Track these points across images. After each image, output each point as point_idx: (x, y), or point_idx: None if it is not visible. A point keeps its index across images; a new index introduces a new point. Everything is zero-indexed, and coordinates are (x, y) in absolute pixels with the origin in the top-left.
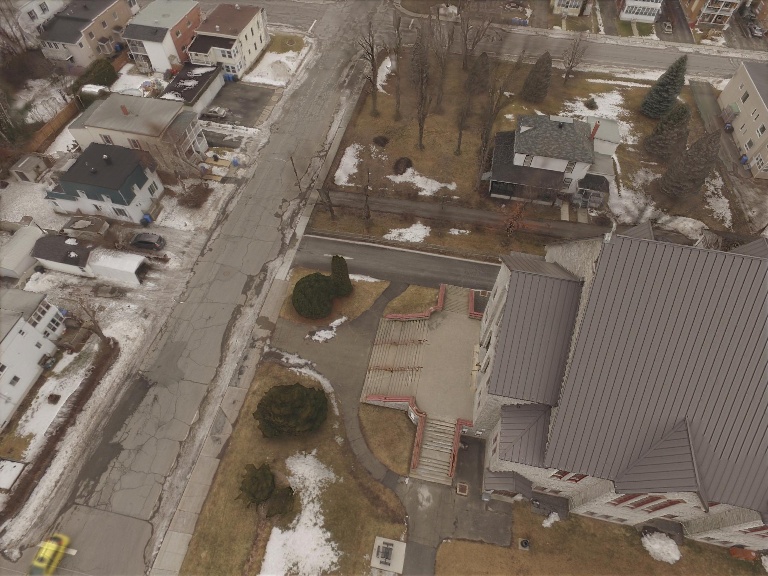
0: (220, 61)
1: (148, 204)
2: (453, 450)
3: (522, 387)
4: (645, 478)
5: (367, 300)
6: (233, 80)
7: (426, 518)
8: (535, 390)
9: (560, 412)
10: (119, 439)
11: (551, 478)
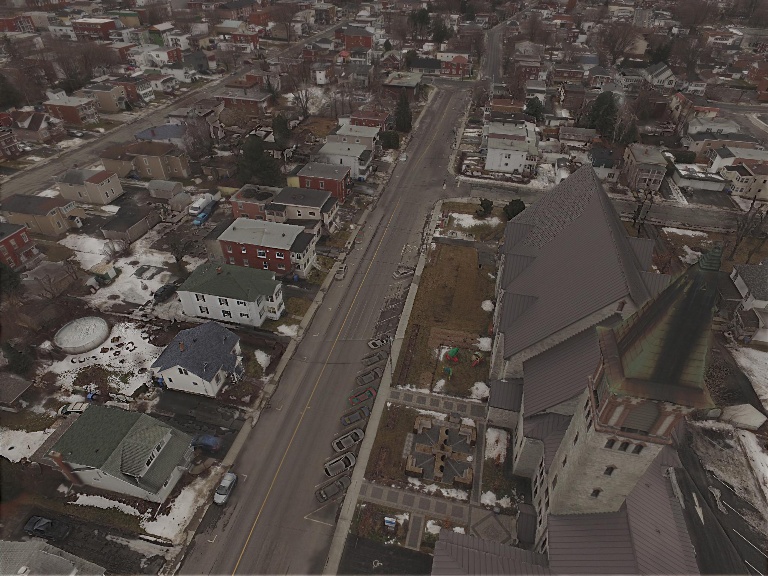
0: (733, 180)
1: (602, 178)
2: None
3: None
4: None
5: None
6: (728, 193)
7: None
8: None
9: None
10: None
11: None
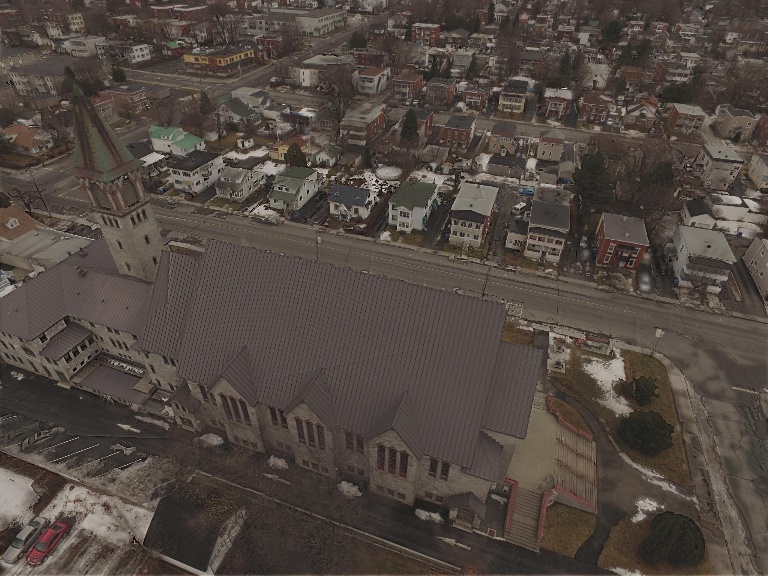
0: None
1: None
2: None
3: None
4: None
5: (618, 539)
6: None
7: None
8: None
9: None
10: (763, 442)
11: None
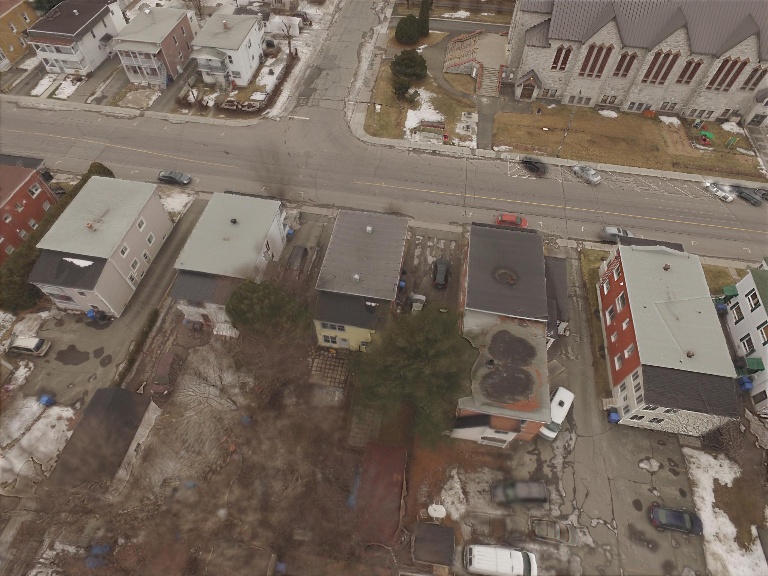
0: None
1: None
2: (499, 79)
3: (537, 5)
4: (594, 29)
5: (438, 38)
6: None
7: (487, 107)
8: (543, 6)
9: (555, 5)
10: (314, 86)
11: (551, 70)
